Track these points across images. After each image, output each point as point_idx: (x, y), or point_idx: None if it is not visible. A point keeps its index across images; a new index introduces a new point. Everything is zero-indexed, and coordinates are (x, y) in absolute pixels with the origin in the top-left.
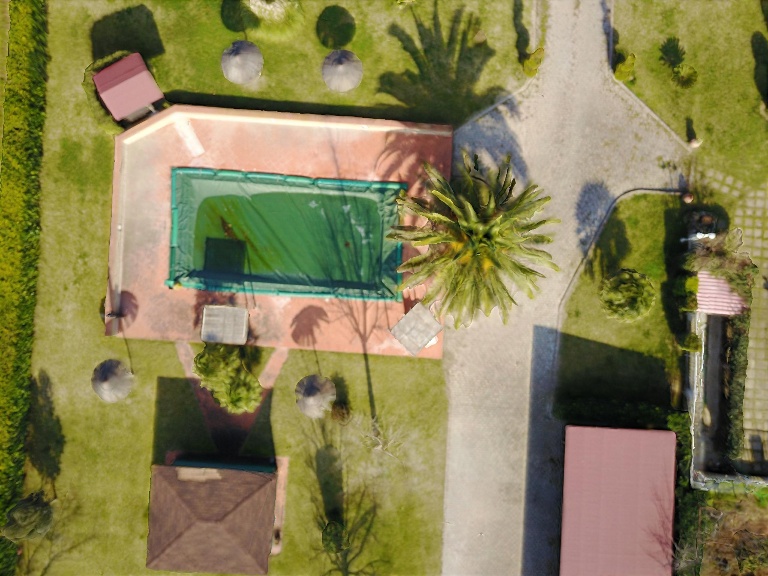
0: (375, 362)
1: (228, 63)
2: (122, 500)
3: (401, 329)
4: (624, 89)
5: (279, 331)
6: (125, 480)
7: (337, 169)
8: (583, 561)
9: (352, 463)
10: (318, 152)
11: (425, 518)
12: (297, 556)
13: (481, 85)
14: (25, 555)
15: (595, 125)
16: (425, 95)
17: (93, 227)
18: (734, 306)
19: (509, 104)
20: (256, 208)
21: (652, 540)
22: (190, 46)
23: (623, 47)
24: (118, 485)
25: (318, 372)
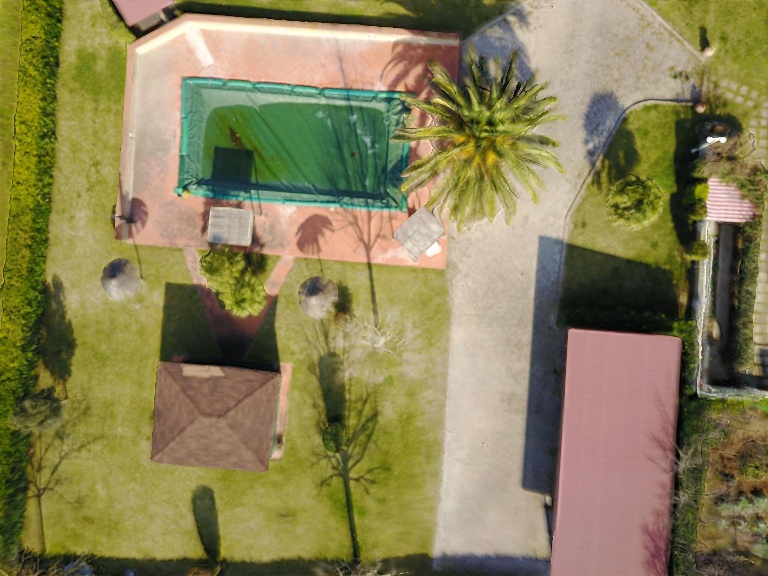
0: (379, 271)
1: None
2: (130, 402)
3: (404, 232)
4: None
5: (284, 239)
6: (133, 382)
7: (344, 79)
8: (584, 465)
9: (355, 371)
10: (325, 62)
11: (427, 427)
12: (299, 461)
13: None
14: (38, 453)
15: (605, 35)
16: (432, 4)
17: (106, 136)
18: (745, 214)
19: (517, 15)
20: (263, 118)
21: (656, 446)
22: None
23: None
24: (127, 387)
25: None
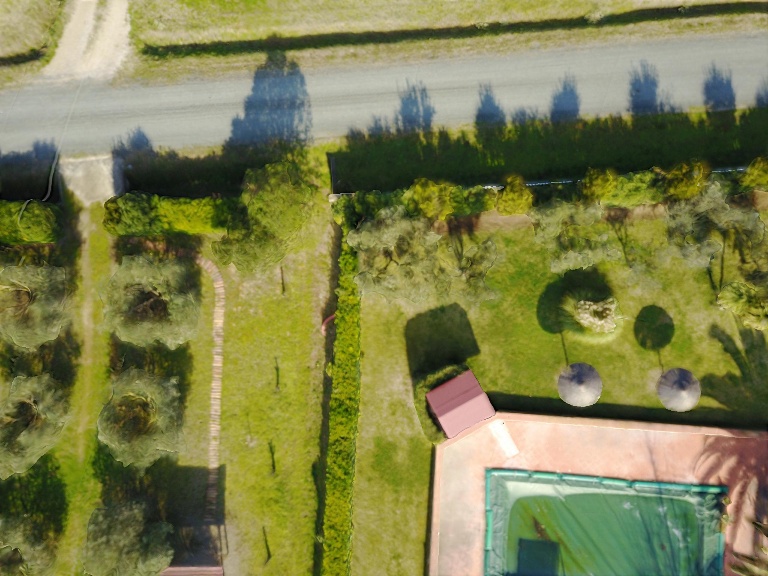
0: None
1: (568, 388)
2: None
3: None
4: None
5: None
6: None
7: (654, 471)
8: None
9: None
10: (634, 453)
11: None
12: None
13: None
14: None
15: None
16: (747, 397)
17: (407, 528)
18: None
19: None
20: (569, 508)
21: None
22: (505, 347)
23: None
24: None
25: None
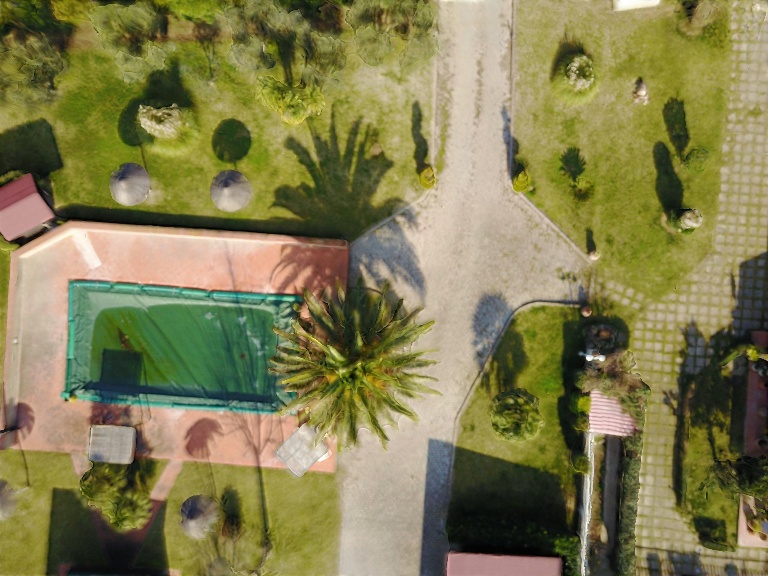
0: (269, 474)
1: (114, 186)
2: None
3: (286, 450)
4: (523, 199)
5: (174, 443)
6: None
7: (233, 281)
8: None
9: None
10: (214, 264)
11: None
12: None
13: (378, 197)
14: None
15: (494, 236)
16: (320, 208)
17: None
18: (627, 428)
19: (407, 214)
20: (153, 319)
21: None
22: (87, 160)
23: (523, 157)
24: None
25: (212, 484)
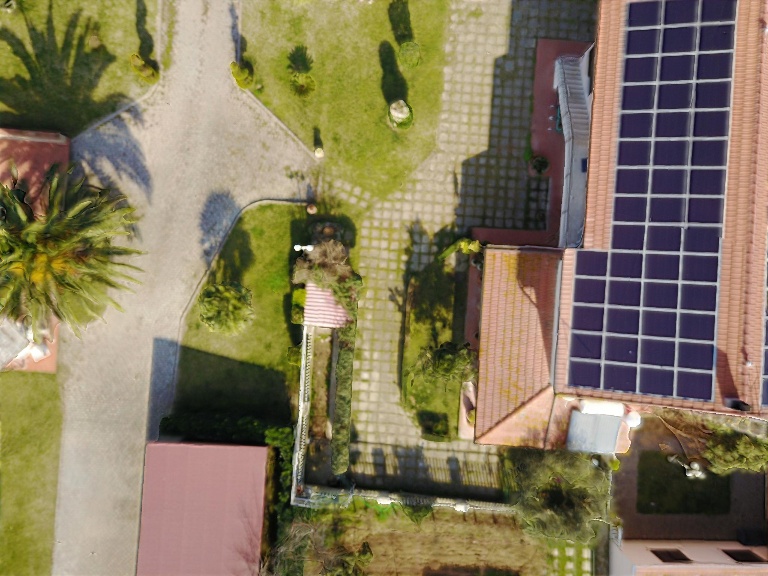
0: None
1: None
2: None
3: None
4: (252, 97)
5: None
6: None
7: None
8: None
9: None
10: None
11: (35, 538)
12: None
13: (99, 92)
14: None
15: (222, 134)
16: (36, 102)
17: None
18: (339, 319)
19: (133, 112)
20: None
21: (238, 558)
22: None
23: (251, 55)
24: None
25: None
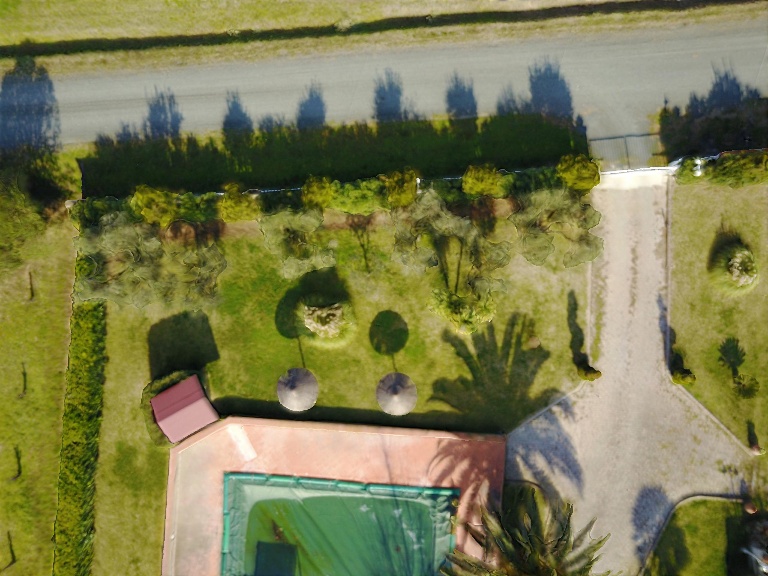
0: None
1: (284, 393)
2: None
3: None
4: (682, 390)
5: None
6: None
7: (389, 474)
8: None
9: None
10: (370, 456)
11: None
12: None
13: (535, 388)
14: None
15: (652, 427)
16: (478, 401)
17: (146, 532)
18: None
19: (563, 404)
20: (307, 511)
21: None
22: (244, 352)
23: (680, 346)
24: None
25: None
